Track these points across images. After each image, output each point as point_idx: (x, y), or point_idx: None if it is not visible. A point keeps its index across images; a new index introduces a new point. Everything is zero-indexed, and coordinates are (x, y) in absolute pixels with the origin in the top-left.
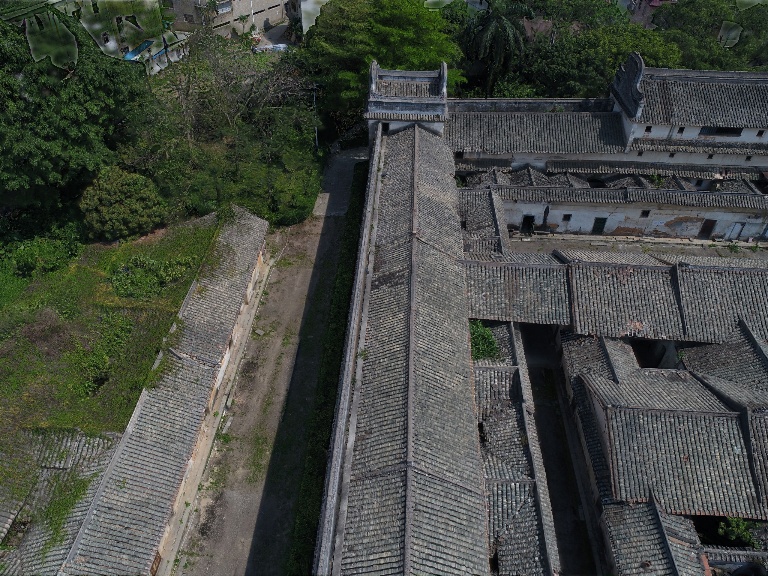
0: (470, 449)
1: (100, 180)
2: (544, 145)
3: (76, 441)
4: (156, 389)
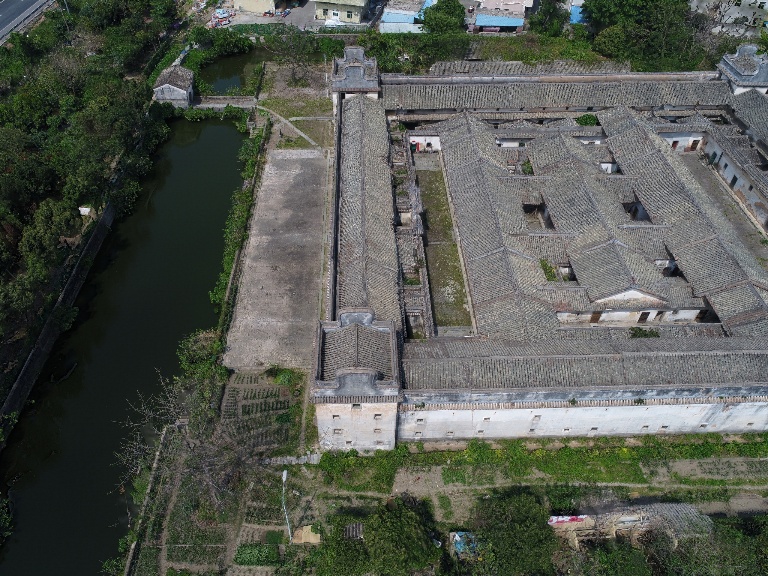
0: (524, 103)
1: (611, 27)
2: (759, 125)
3: (500, 58)
4: (524, 65)
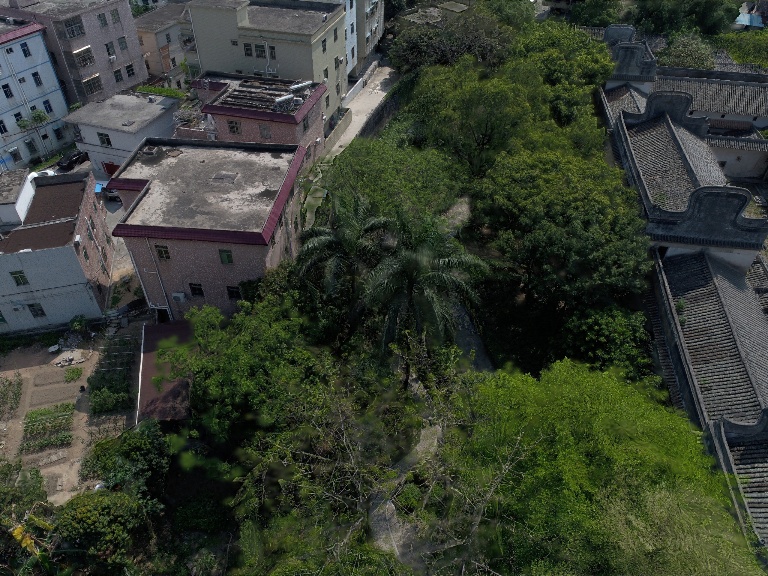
0: None
1: None
2: None
3: None
4: None
